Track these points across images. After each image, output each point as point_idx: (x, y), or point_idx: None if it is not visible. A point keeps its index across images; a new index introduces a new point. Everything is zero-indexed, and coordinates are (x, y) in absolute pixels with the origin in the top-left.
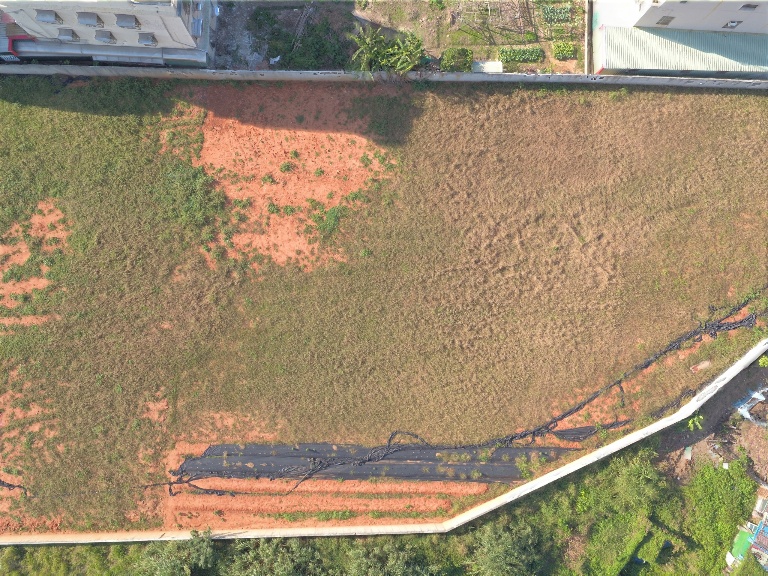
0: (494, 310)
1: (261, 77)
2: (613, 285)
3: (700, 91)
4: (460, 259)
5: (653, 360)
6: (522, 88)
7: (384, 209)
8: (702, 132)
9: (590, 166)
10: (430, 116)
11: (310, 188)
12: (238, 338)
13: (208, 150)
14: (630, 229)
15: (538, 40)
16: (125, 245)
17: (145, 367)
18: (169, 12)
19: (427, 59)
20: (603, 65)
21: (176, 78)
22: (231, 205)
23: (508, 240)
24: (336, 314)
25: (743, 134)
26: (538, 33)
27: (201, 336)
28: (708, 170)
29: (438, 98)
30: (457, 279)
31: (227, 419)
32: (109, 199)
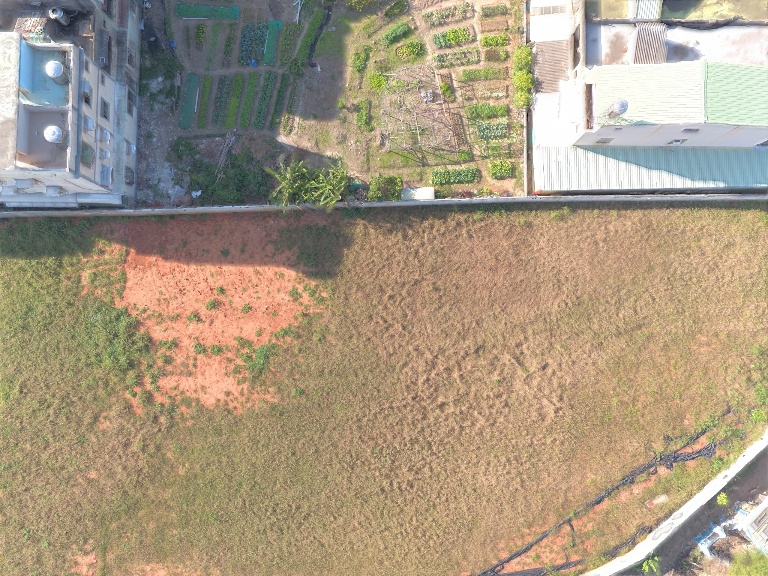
0: (433, 449)
1: (184, 212)
2: (560, 417)
3: (650, 205)
4: (396, 395)
5: (605, 496)
6: (458, 211)
7: (315, 345)
8: (652, 249)
9: (533, 291)
10: (361, 245)
11: (238, 326)
12: (167, 486)
13: (131, 290)
14: (577, 357)
15: (474, 159)
16: (48, 394)
17: (71, 520)
18: (67, 175)
19: (357, 185)
20: (541, 187)
21: (96, 216)
22: (156, 347)
23: (447, 373)
24: (267, 458)
25: (697, 250)
26: (474, 151)
27: (128, 486)
28: (660, 290)
29: (370, 225)
30: (394, 417)
31: (157, 571)
32: (30, 346)
